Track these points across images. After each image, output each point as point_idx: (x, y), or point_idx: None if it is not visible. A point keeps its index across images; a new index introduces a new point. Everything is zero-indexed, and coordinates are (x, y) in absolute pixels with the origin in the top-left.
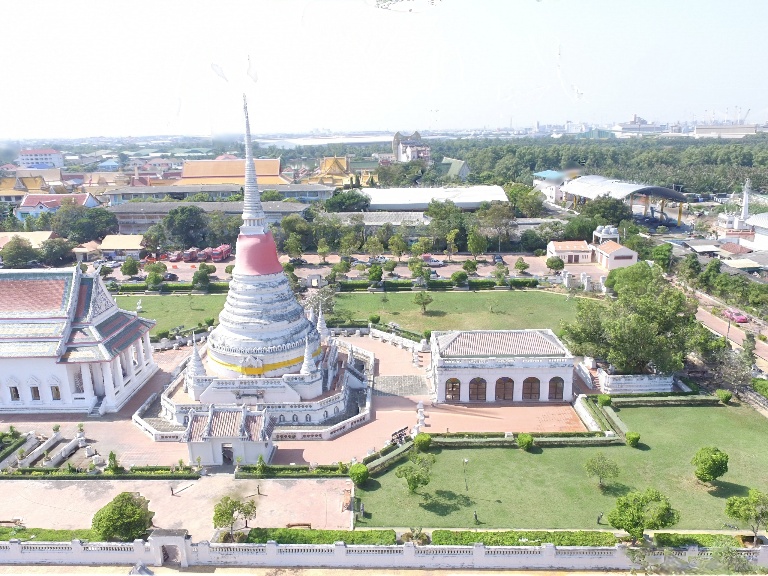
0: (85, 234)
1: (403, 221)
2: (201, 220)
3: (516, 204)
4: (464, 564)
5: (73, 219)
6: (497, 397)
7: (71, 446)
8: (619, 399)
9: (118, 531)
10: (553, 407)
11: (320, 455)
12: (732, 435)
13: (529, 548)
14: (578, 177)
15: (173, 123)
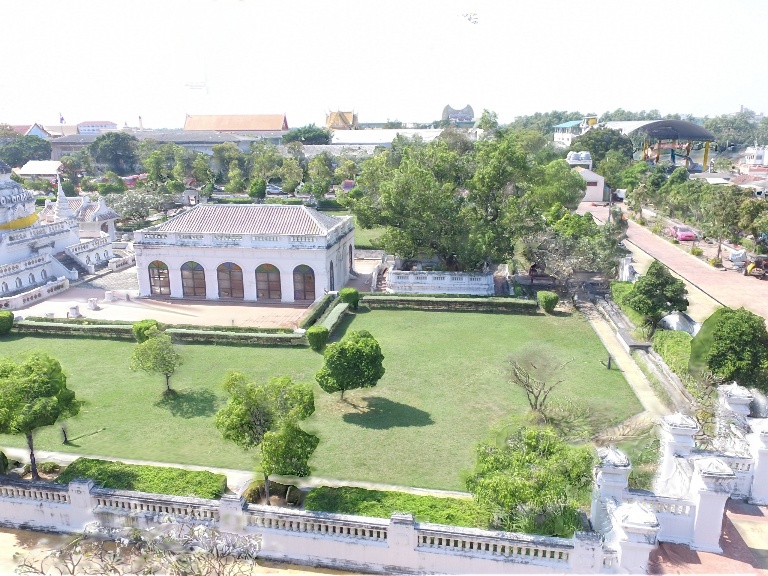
0: (11, 160)
1: (343, 149)
2: (129, 147)
3: None
4: None
5: None
6: (225, 294)
7: None
8: (375, 296)
9: None
10: (290, 309)
11: None
12: (504, 346)
13: None
14: None
15: None
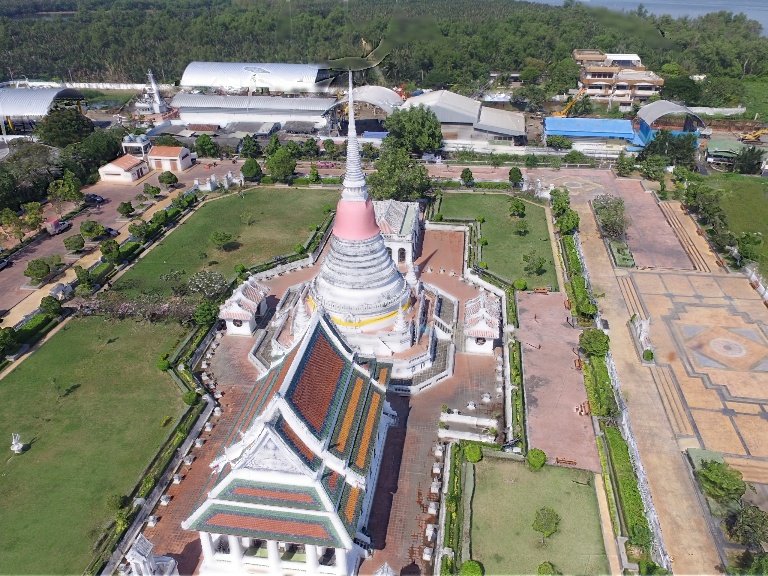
0: None
1: None
2: None
3: None
4: None
5: None
6: None
7: None
8: None
9: None
10: None
11: None
12: None
13: None
14: None
15: (2, 121)
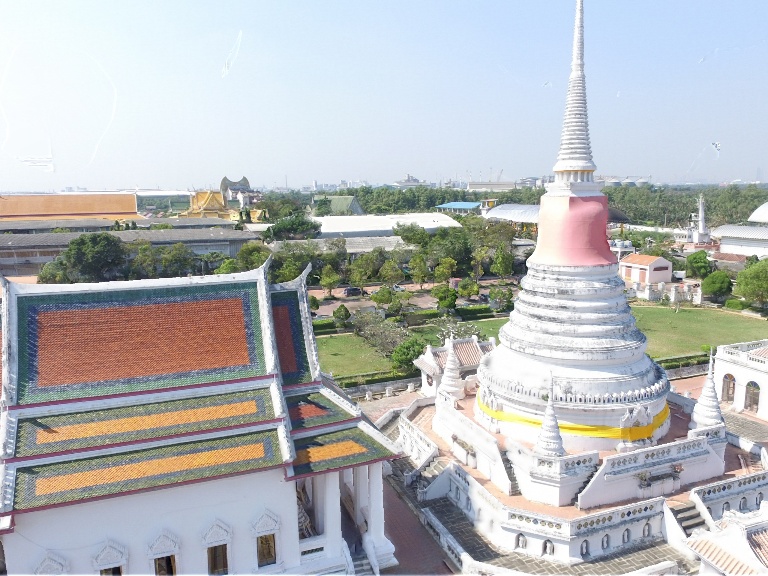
0: None
1: (397, 244)
2: (122, 252)
3: None
4: None
5: None
6: None
7: None
8: None
9: None
10: None
11: None
12: None
13: None
14: (497, 206)
15: (233, 65)
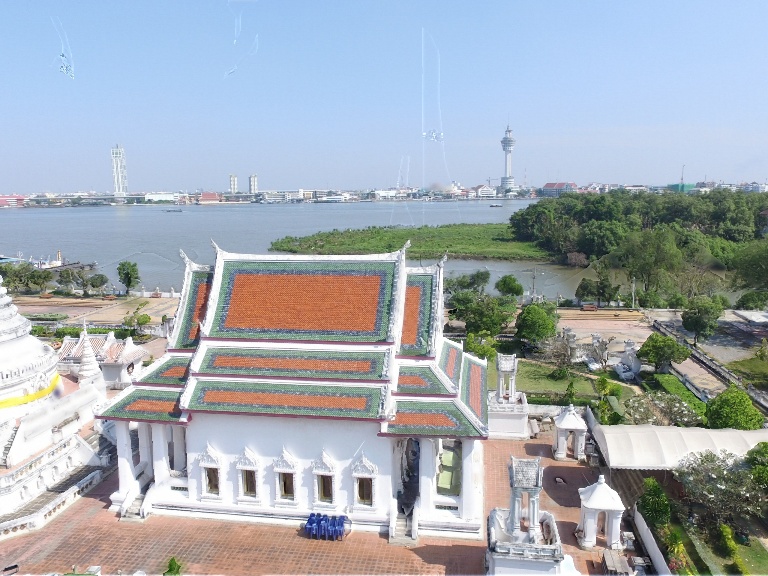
0: None
1: None
2: None
3: None
4: None
5: None
6: None
7: None
8: None
9: None
10: None
11: None
12: None
13: None
14: None
15: None
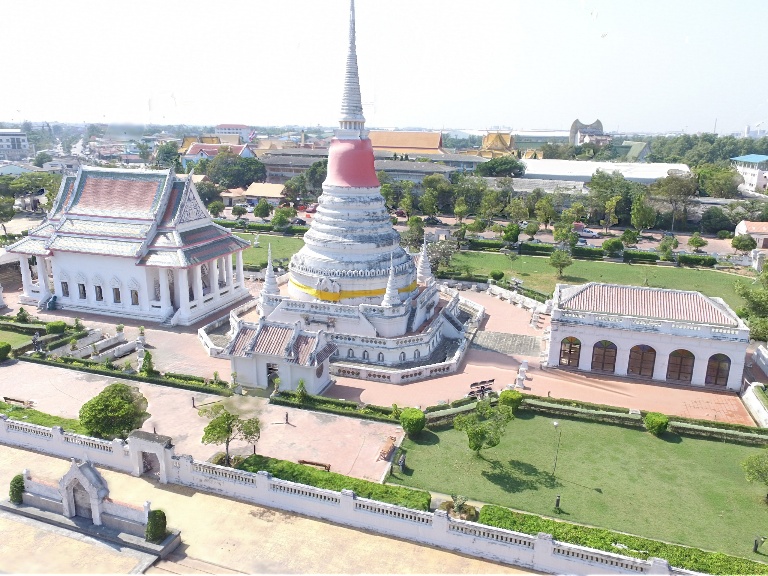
0: (234, 181)
1: (557, 187)
2: None
3: (703, 186)
4: (519, 560)
5: (227, 166)
6: (630, 371)
7: (127, 347)
8: None
9: (100, 425)
10: (710, 394)
11: (381, 398)
12: None
13: (624, 558)
14: None
15: (303, 44)
